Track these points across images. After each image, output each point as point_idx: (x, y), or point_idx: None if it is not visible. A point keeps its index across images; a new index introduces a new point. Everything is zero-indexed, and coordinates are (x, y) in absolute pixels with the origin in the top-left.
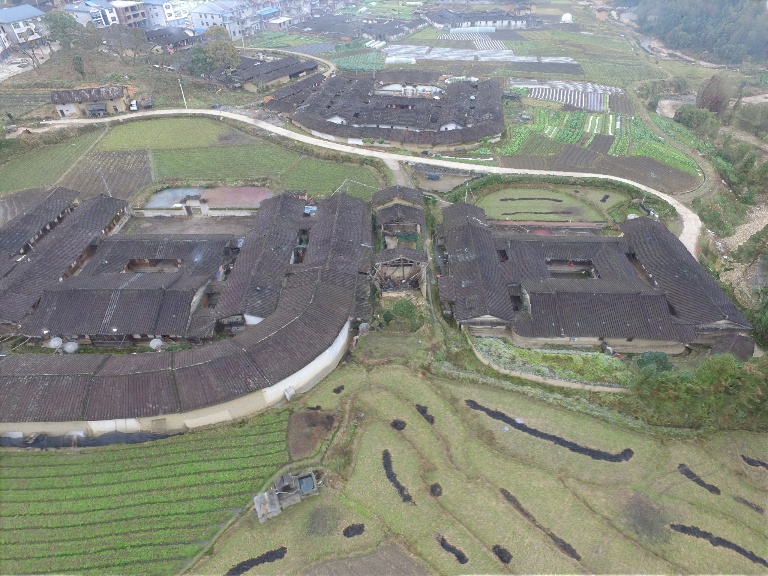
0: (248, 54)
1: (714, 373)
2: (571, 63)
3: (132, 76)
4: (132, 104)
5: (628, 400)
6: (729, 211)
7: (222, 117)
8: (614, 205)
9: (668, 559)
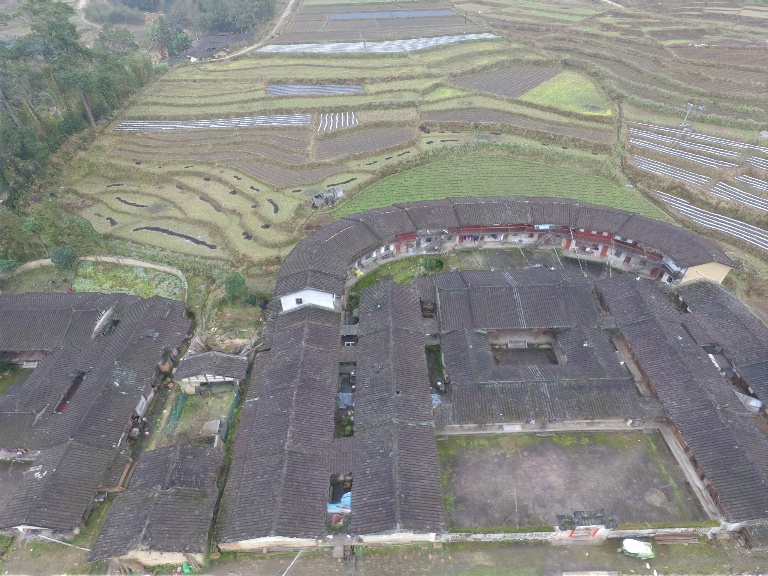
0: None
1: None
2: None
3: None
4: None
5: None
6: None
7: None
8: None
9: None
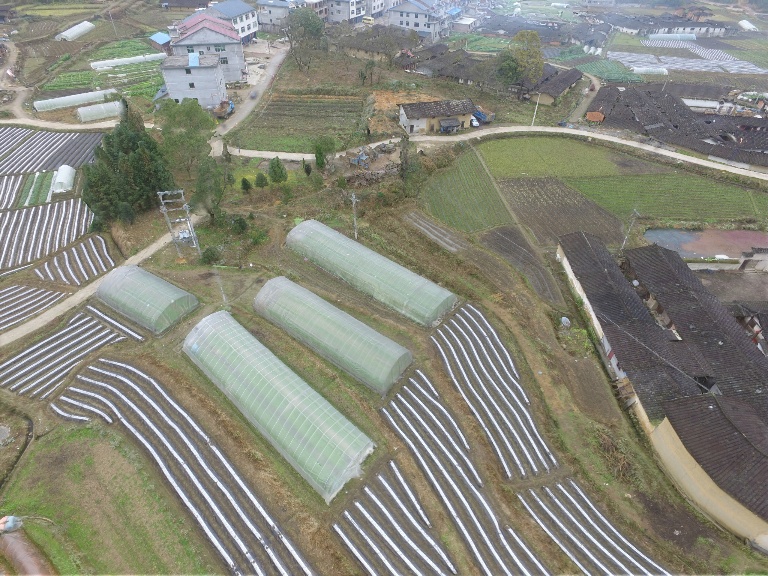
0: (473, 58)
1: None
2: None
3: (418, 84)
4: (473, 119)
5: None
6: None
7: (590, 138)
8: None
9: None
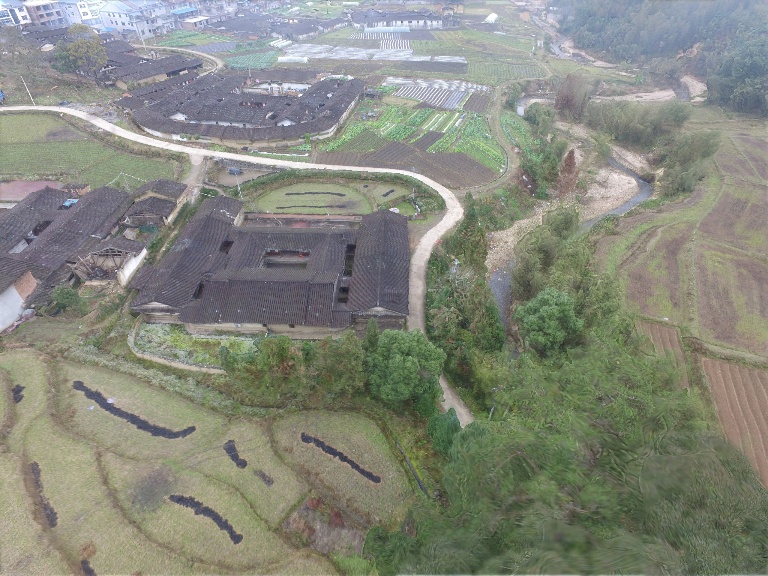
0: (147, 53)
1: (263, 353)
2: (460, 62)
3: (2, 73)
4: None
5: (233, 382)
6: (513, 206)
7: (62, 113)
8: (392, 199)
9: (142, 526)
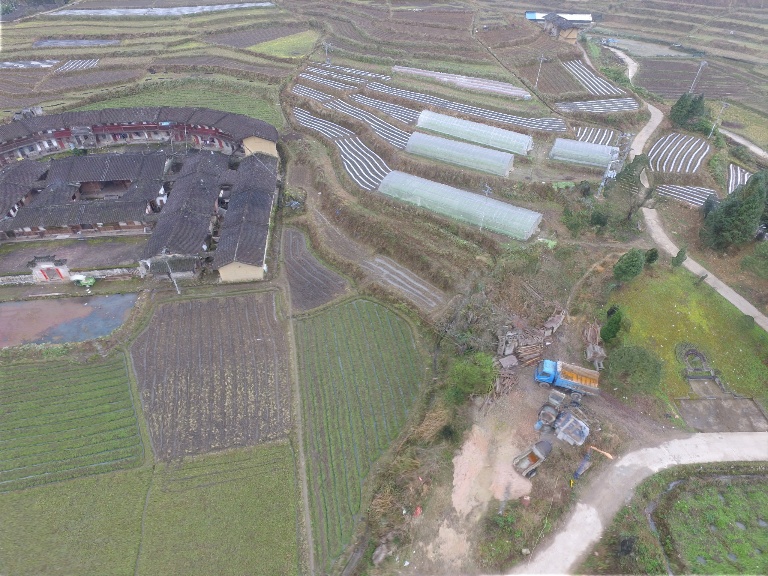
0: None
1: None
2: None
3: None
4: None
5: None
6: None
7: None
8: None
9: None
